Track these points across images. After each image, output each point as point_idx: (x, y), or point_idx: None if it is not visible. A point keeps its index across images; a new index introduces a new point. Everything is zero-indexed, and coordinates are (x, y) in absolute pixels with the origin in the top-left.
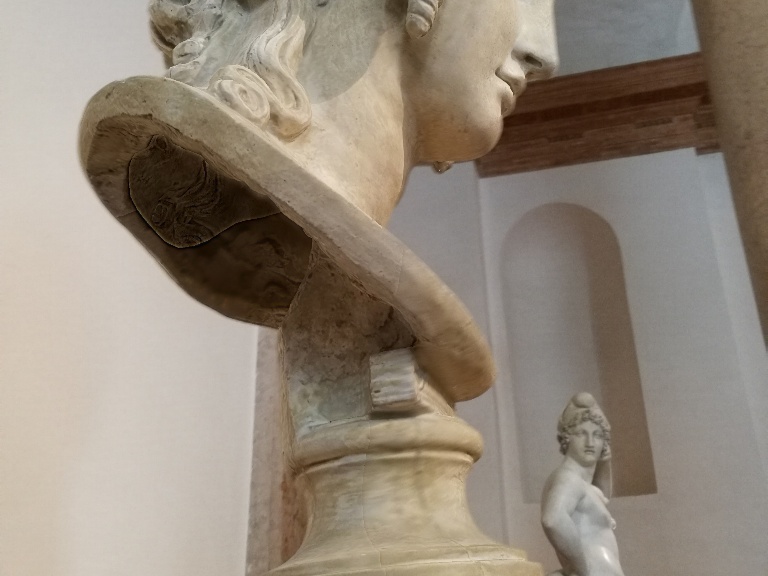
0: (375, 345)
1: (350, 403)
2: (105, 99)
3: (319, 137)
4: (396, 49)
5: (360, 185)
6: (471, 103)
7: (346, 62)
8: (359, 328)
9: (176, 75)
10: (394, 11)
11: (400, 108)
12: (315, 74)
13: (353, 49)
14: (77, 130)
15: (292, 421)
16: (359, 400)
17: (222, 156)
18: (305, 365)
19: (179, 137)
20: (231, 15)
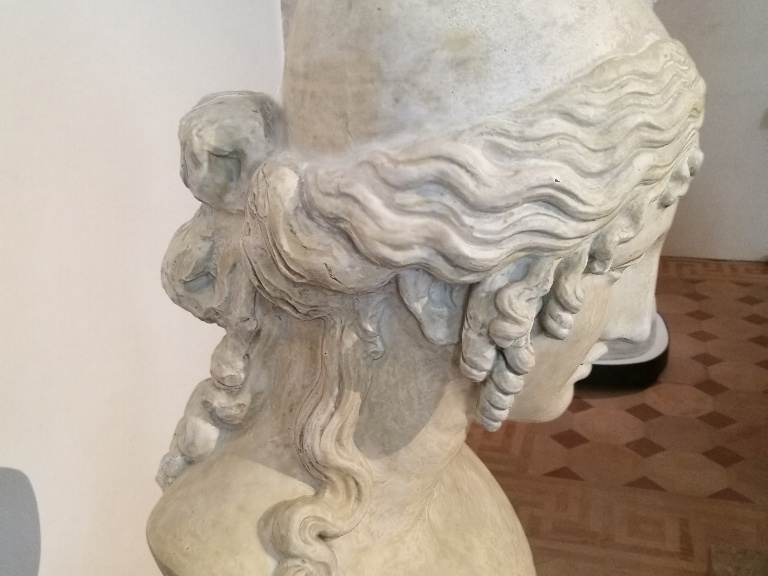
0: None
1: None
2: None
3: (381, 488)
4: (462, 393)
5: (421, 497)
6: (541, 414)
7: (407, 418)
8: None
9: (222, 417)
10: None
11: (464, 424)
12: (374, 433)
13: (414, 405)
14: None
15: None
16: None
17: None
18: None
19: None
20: (268, 321)
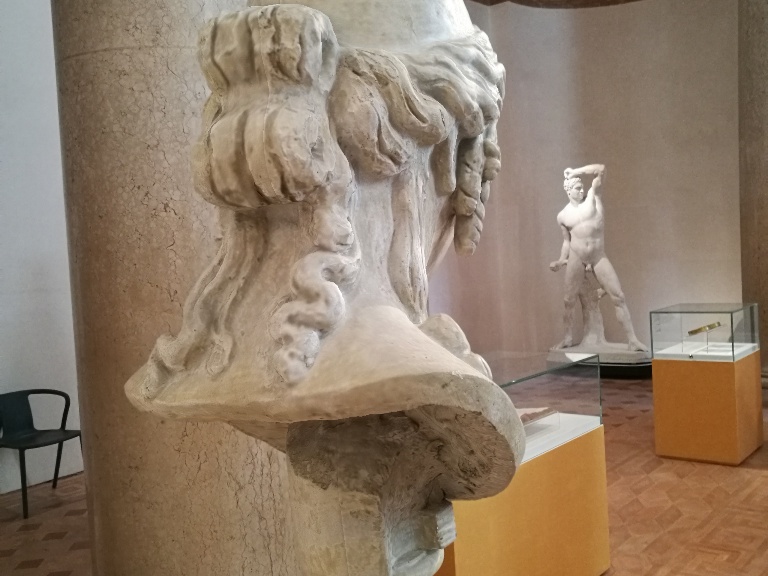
0: (422, 498)
1: (404, 541)
2: (441, 388)
3: None
4: None
5: None
6: None
7: None
8: (417, 488)
9: (349, 275)
10: (443, 217)
11: None
12: None
13: None
14: (376, 391)
15: (388, 568)
16: (410, 538)
17: (510, 446)
18: (388, 522)
19: (487, 428)
20: None
